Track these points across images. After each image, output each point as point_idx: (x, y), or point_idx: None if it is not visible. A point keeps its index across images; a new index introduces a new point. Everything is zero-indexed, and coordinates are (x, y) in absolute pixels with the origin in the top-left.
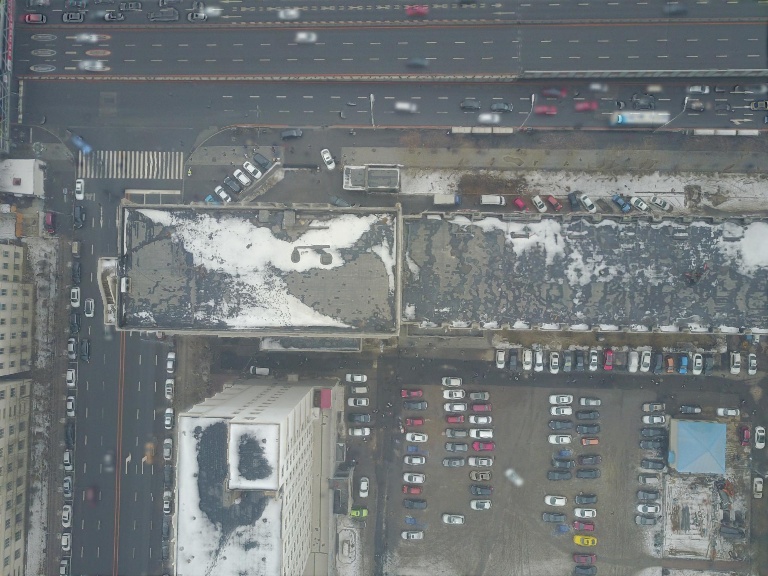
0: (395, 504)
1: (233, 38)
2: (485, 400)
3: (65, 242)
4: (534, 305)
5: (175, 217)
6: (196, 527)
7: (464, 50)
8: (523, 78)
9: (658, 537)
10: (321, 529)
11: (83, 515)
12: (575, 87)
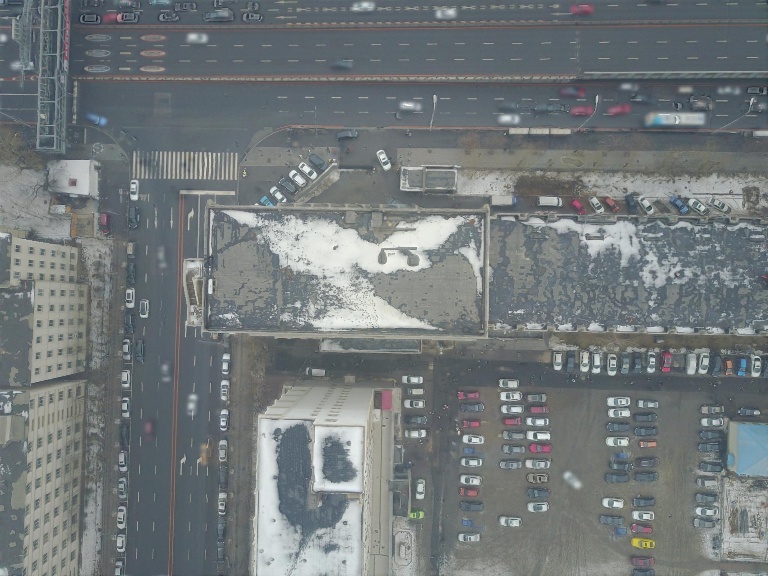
0: (451, 506)
1: (288, 39)
2: (542, 402)
3: (120, 243)
4: (609, 307)
5: (261, 218)
6: (276, 529)
7: (521, 51)
8: (581, 79)
9: (716, 540)
10: (381, 531)
11: (138, 516)
12: (632, 88)
